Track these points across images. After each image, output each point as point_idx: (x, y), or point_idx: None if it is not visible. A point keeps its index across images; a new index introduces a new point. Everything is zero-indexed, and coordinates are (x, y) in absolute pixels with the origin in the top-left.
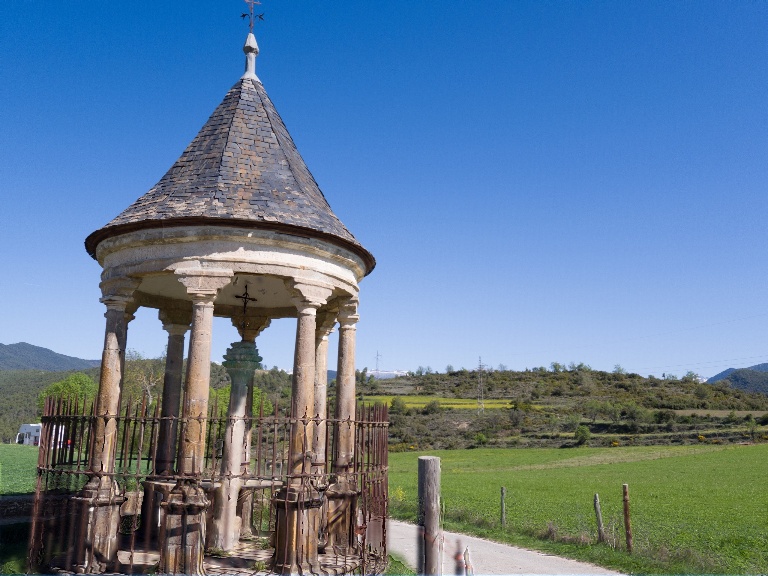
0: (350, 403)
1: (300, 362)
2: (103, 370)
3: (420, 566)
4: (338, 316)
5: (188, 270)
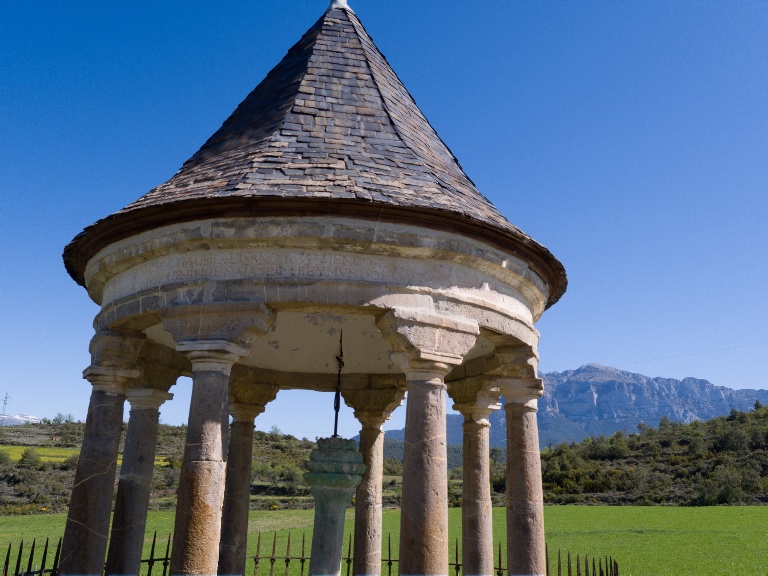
0: (491, 546)
1: (532, 493)
2: (194, 509)
3: None
4: (475, 404)
5: (419, 312)
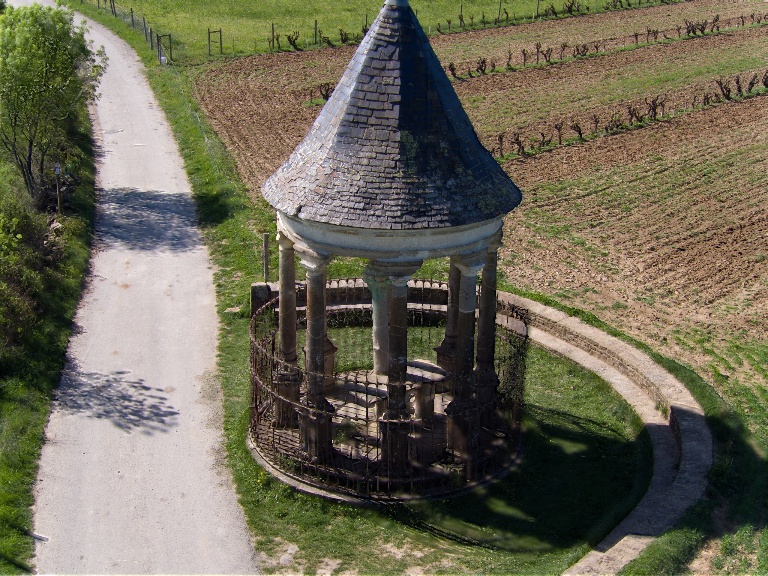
0: None
1: None
2: None
3: (212, 481)
4: None
5: None
